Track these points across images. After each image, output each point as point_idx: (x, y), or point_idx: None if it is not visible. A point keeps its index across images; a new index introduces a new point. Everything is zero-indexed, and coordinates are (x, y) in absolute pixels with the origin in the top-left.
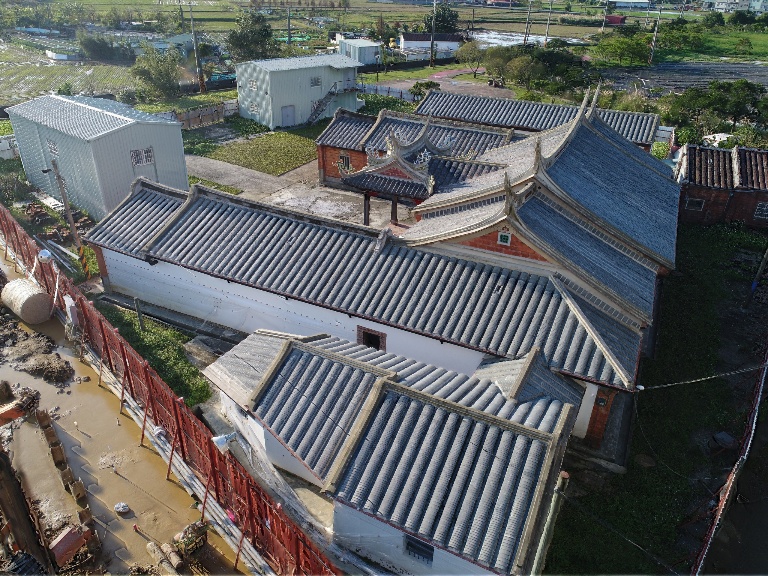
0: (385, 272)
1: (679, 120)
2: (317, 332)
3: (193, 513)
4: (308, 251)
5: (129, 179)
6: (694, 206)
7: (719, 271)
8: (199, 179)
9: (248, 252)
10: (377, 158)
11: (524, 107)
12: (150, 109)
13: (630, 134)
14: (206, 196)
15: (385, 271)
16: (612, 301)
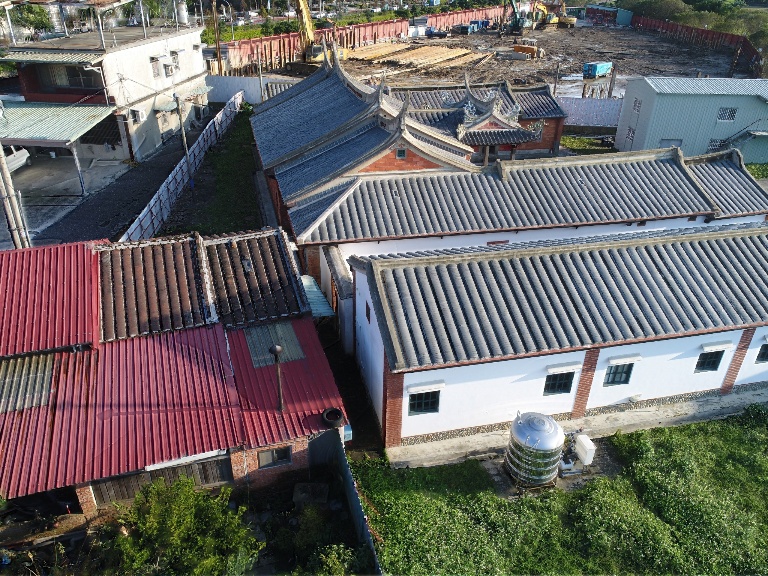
0: None
1: None
2: None
3: None
4: None
5: None
6: None
7: None
8: None
9: None
10: None
11: None
12: None
13: None
14: None
15: None
16: None
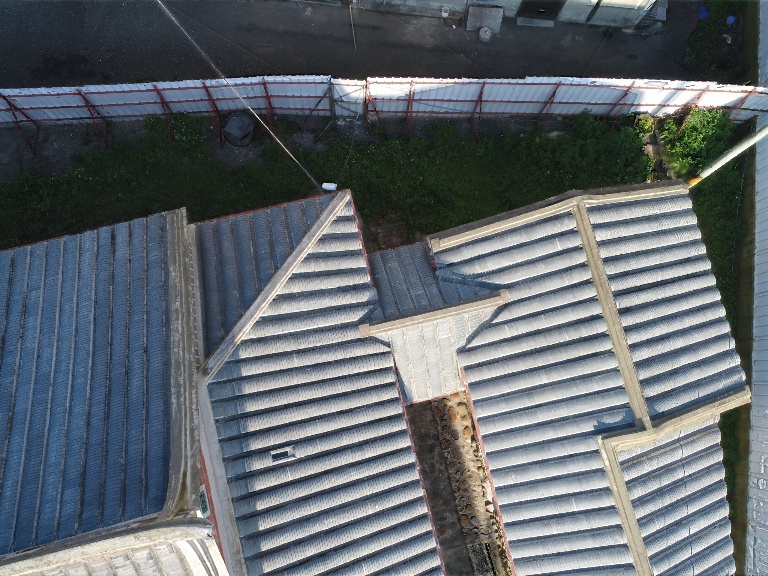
0: None
1: None
2: None
3: (762, 553)
4: None
5: None
6: None
7: None
8: None
9: None
10: None
11: None
12: None
13: None
14: None
15: None
16: None
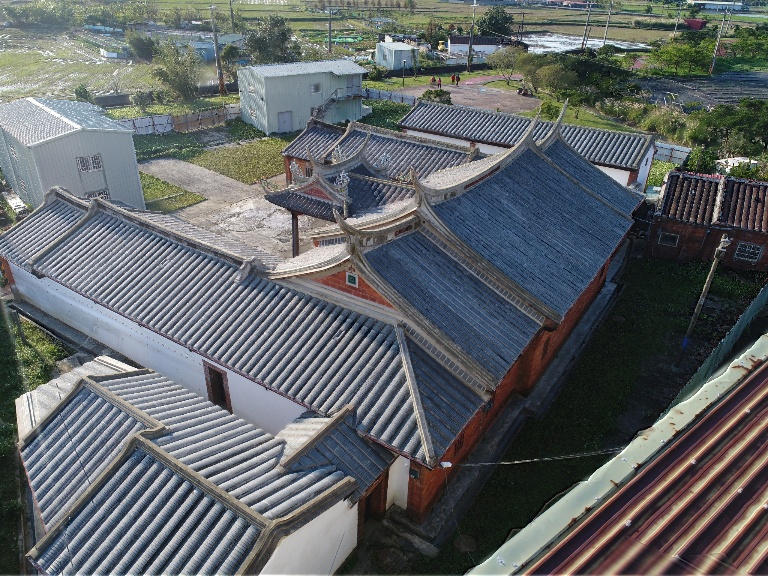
0: (236, 305)
1: (708, 139)
2: (172, 362)
3: None
4: (174, 276)
5: (75, 185)
6: (668, 241)
7: (669, 319)
8: (169, 185)
9: (119, 273)
10: (301, 176)
11: (511, 122)
12: (162, 110)
13: (615, 157)
14: (104, 211)
15: (237, 304)
16: (456, 358)
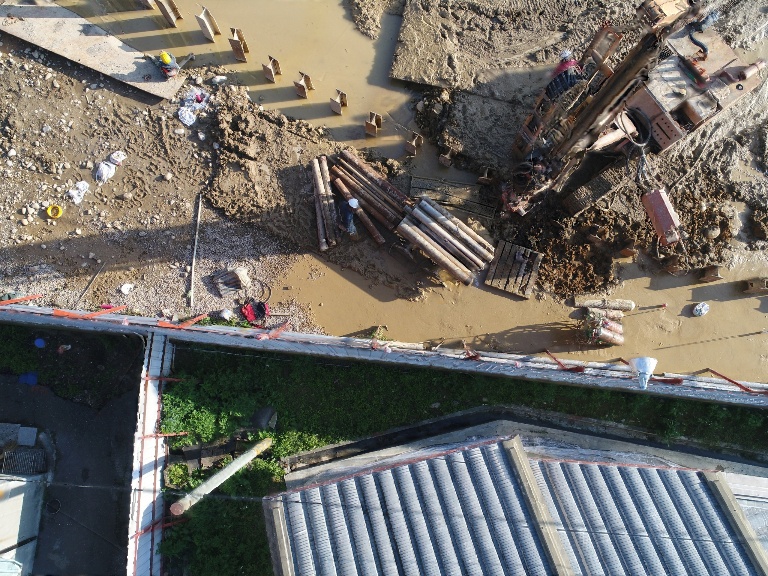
0: None
1: None
2: None
3: None
4: None
5: None
6: None
7: None
8: None
9: None
10: None
11: None
12: None
13: None
14: None
15: None
16: None
